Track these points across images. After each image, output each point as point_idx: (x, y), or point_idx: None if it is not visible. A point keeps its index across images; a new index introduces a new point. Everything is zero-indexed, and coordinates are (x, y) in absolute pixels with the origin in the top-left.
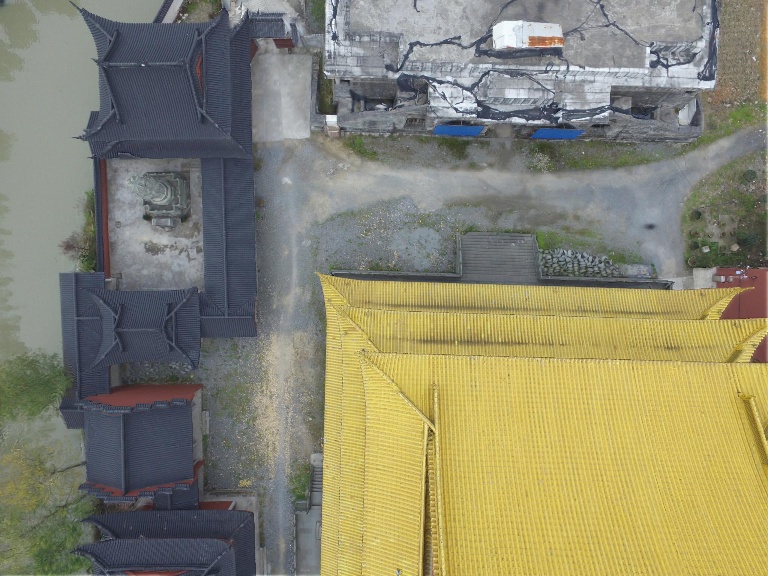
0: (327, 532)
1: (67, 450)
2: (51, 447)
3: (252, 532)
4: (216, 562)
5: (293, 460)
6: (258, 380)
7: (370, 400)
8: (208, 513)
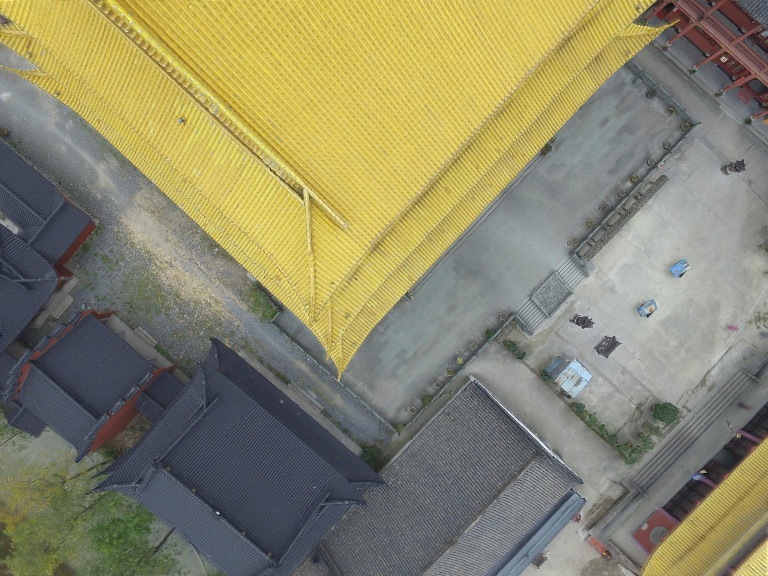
0: (260, 274)
1: (61, 458)
2: (36, 461)
3: (239, 359)
4: (210, 392)
5: (238, 294)
6: (148, 264)
7: (17, 18)
8: (192, 381)
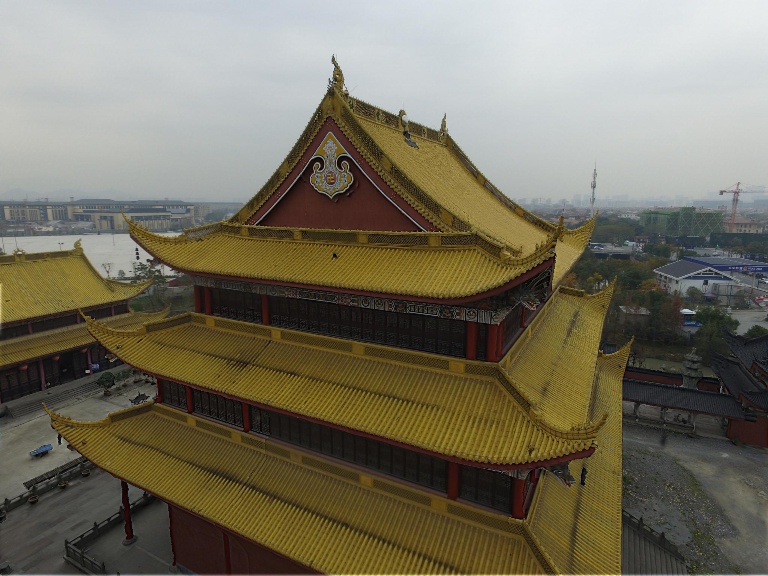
0: None
1: None
2: None
3: None
4: None
5: None
6: None
7: None
8: None
